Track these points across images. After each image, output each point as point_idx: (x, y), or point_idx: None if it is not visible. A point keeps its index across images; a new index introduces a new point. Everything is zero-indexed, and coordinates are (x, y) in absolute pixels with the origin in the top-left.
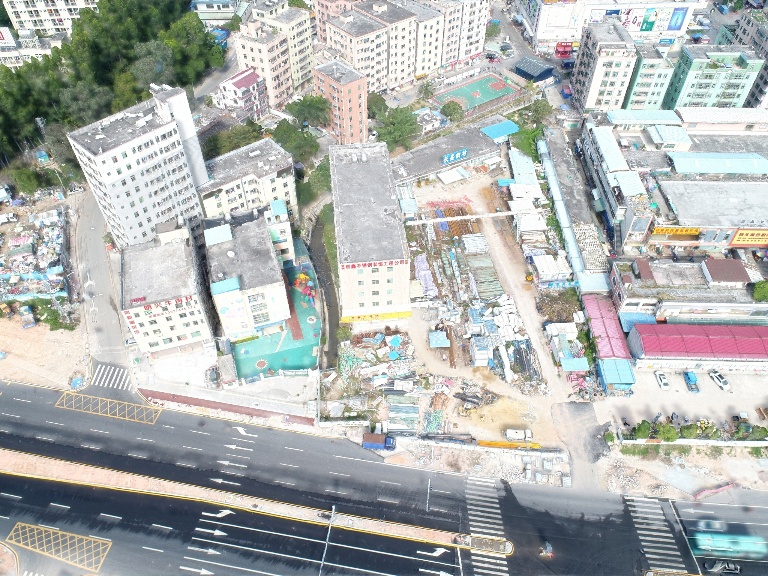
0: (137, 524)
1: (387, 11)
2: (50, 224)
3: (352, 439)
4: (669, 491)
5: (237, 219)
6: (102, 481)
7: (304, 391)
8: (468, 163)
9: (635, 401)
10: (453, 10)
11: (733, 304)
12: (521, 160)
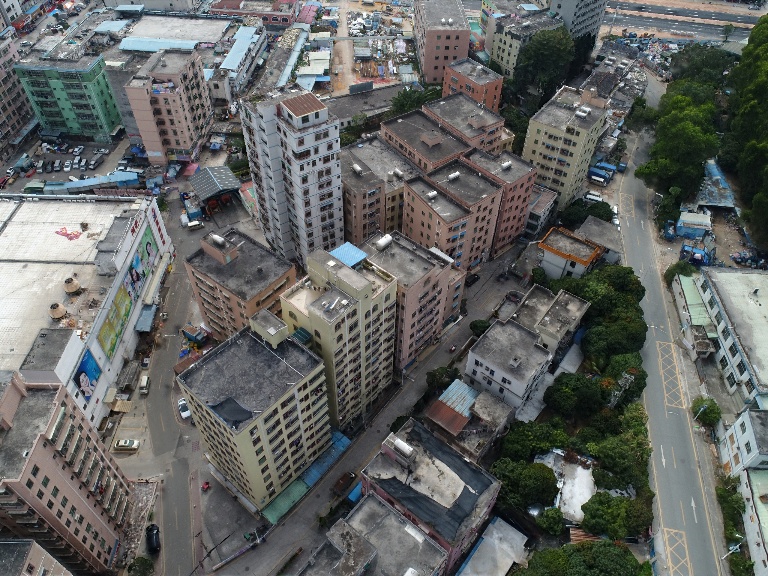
0: None
1: None
2: None
3: None
4: None
5: None
6: None
7: None
8: None
9: None
10: None
11: None
12: None
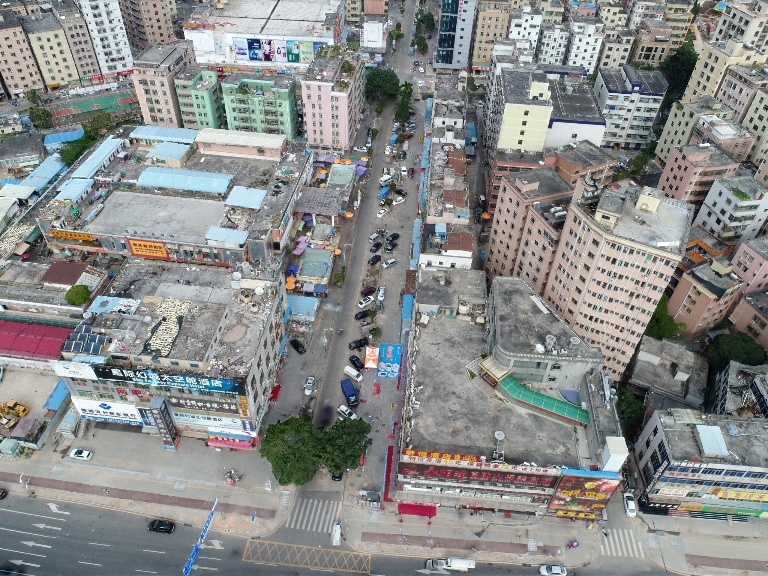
0: None
1: (3, 21)
2: None
3: None
4: None
5: None
6: None
7: None
8: (3, 164)
9: None
10: (73, 26)
11: (41, 304)
12: (51, 165)
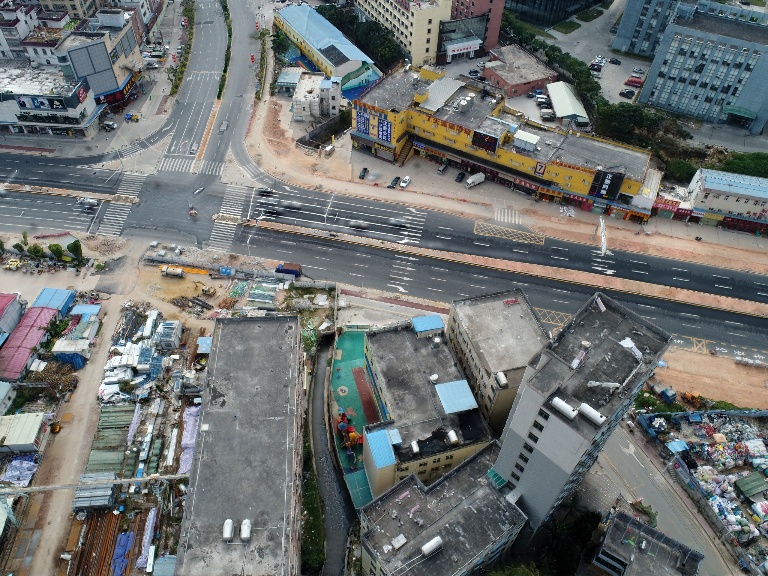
0: (461, 239)
1: None
2: (766, 558)
3: (310, 280)
4: (84, 236)
5: (442, 446)
6: (498, 261)
7: (350, 318)
8: None
9: (54, 288)
10: None
11: None
12: None
